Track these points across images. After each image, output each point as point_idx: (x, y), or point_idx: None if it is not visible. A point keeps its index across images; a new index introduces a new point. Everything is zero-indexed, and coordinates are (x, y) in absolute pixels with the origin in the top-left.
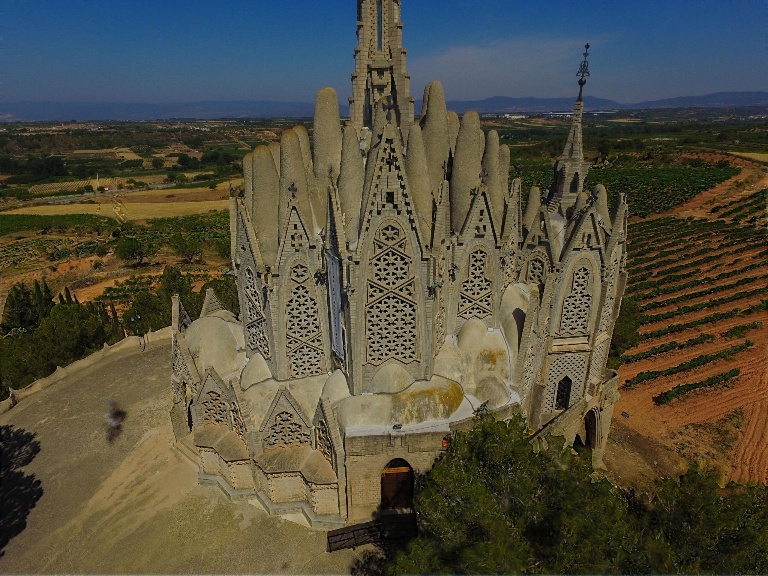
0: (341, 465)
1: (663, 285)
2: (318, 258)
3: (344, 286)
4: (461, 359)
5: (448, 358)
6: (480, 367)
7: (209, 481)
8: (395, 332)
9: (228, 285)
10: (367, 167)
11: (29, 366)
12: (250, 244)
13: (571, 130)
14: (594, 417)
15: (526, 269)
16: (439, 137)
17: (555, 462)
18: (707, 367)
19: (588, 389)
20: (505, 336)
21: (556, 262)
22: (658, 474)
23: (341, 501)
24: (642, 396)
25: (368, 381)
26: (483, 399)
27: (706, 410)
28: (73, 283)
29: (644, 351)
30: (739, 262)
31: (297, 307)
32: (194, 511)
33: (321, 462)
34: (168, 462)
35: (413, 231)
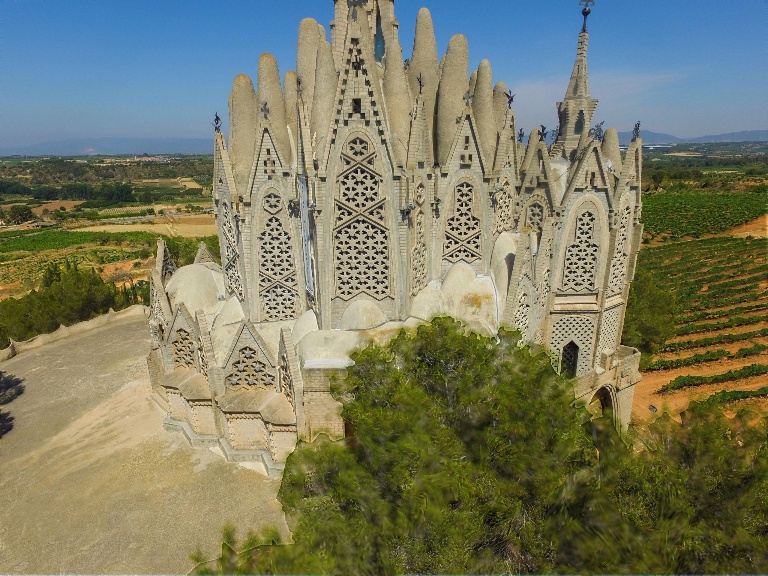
0: (300, 403)
1: (714, 299)
2: (292, 187)
3: (310, 206)
4: (442, 301)
5: (427, 299)
6: (463, 311)
7: (174, 426)
8: (366, 262)
9: None
10: None
11: (34, 322)
12: (224, 172)
13: None
14: (610, 399)
15: (524, 217)
16: (426, 67)
17: (507, 360)
18: (761, 378)
19: (599, 360)
20: (495, 282)
21: (556, 205)
22: None
23: None
24: (681, 402)
25: (337, 318)
26: None
27: None
28: (111, 277)
29: None
30: None
31: (270, 241)
32: (152, 453)
33: (282, 404)
34: (140, 409)
35: (383, 145)
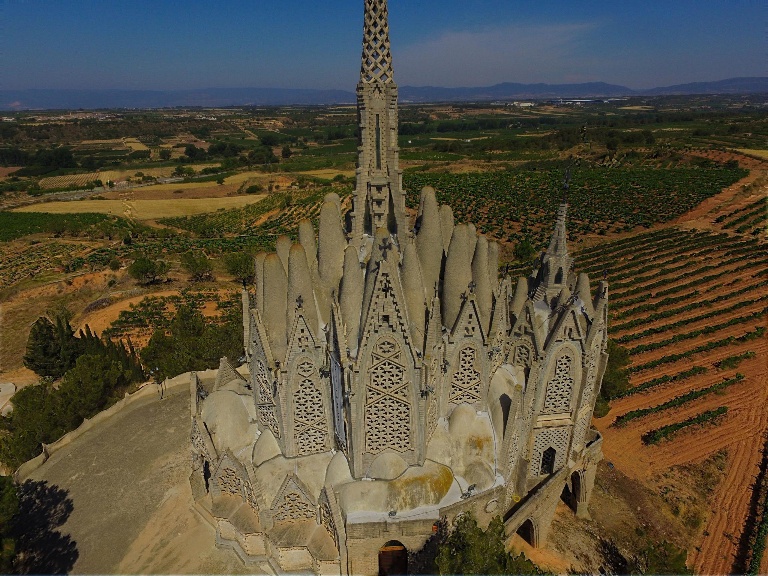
0: (343, 545)
1: (661, 307)
2: (322, 356)
3: (345, 390)
4: (451, 445)
5: (439, 444)
6: (468, 452)
7: (225, 546)
8: (391, 427)
9: (238, 320)
10: (366, 286)
11: (58, 419)
12: (261, 343)
13: (556, 228)
14: (578, 476)
15: (513, 353)
16: (433, 243)
17: None
18: (697, 402)
19: (571, 455)
20: (492, 421)
21: (540, 351)
22: (640, 521)
23: (343, 574)
24: (631, 434)
25: (367, 466)
26: (471, 482)
27: (692, 450)
28: (90, 304)
29: (637, 384)
30: (738, 282)
31: (304, 396)
32: None
33: (325, 538)
34: (188, 524)
35: (407, 345)
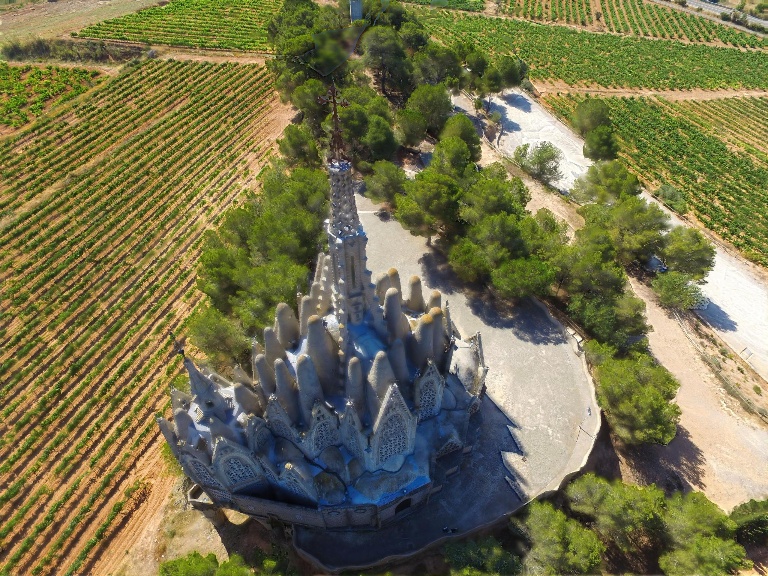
0: None
1: None
2: None
3: None
4: None
5: None
6: None
7: None
8: None
9: None
10: None
11: None
12: None
13: None
14: None
15: None
16: None
17: None
18: None
19: None
20: None
21: None
22: (164, 559)
23: None
24: None
25: None
26: None
27: None
28: None
29: None
30: None
31: None
32: None
33: None
34: None
35: None
